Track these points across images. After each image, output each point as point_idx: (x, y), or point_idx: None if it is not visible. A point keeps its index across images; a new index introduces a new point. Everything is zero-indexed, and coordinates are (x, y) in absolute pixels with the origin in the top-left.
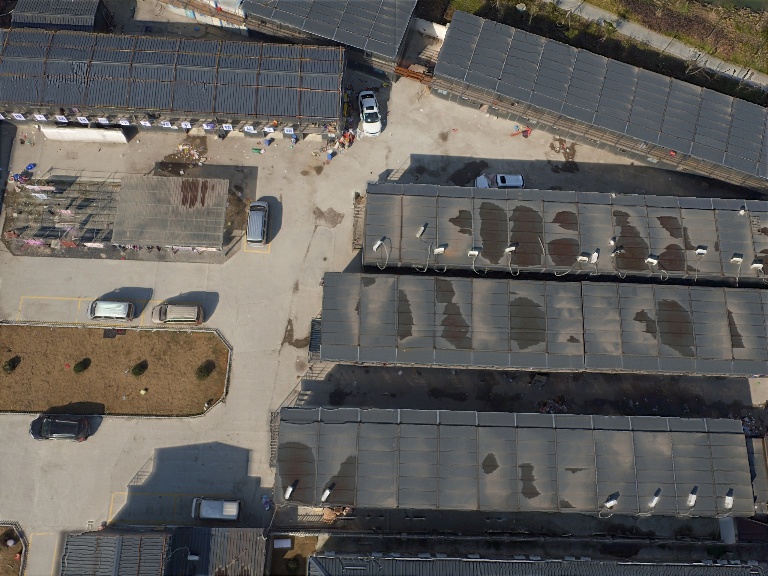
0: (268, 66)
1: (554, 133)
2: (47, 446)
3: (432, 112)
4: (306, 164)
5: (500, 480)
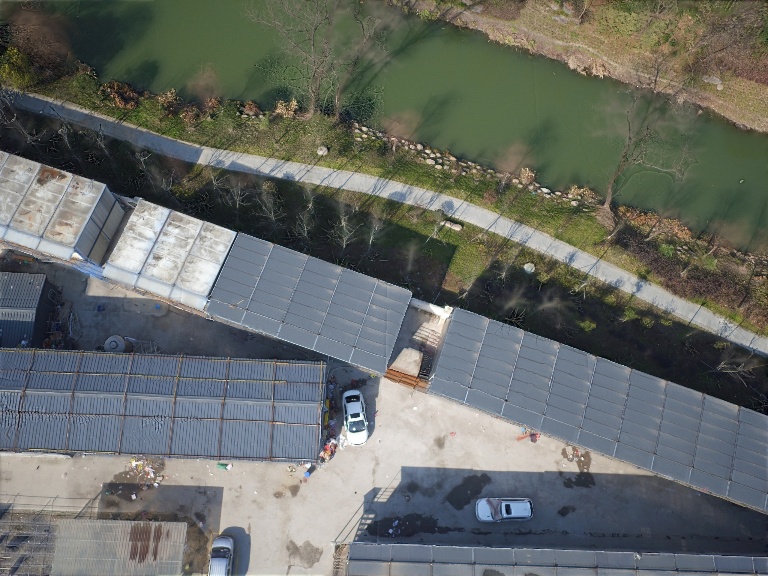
0: (235, 393)
1: None
2: None
3: (427, 410)
4: (280, 482)
5: None
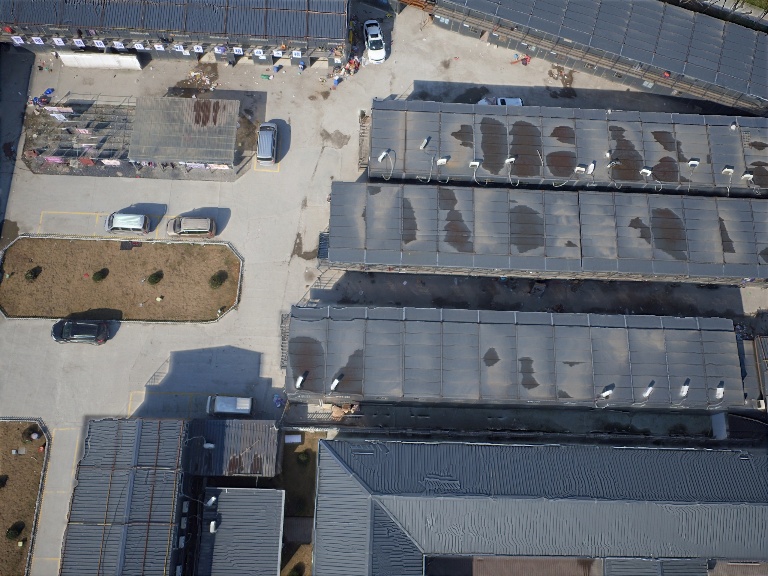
0: None
1: (552, 60)
2: (68, 349)
3: (434, 41)
4: (313, 89)
5: (501, 372)
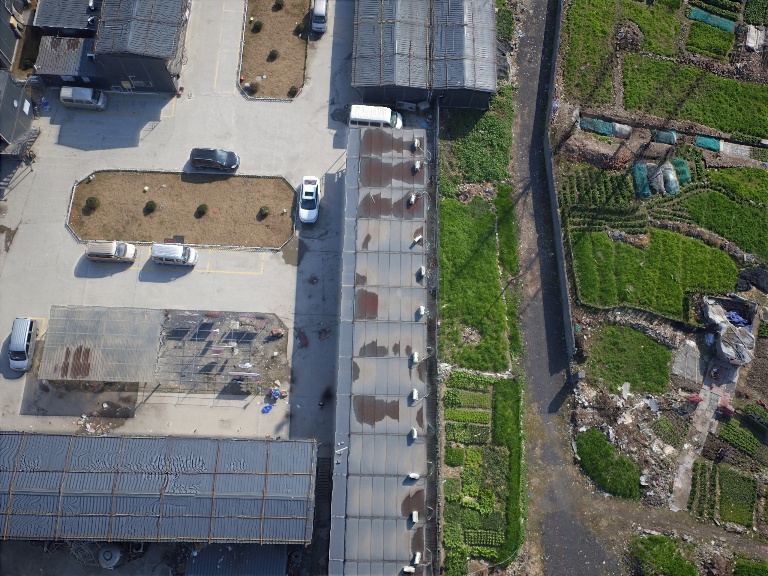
0: None
1: None
2: None
3: None
4: None
5: None
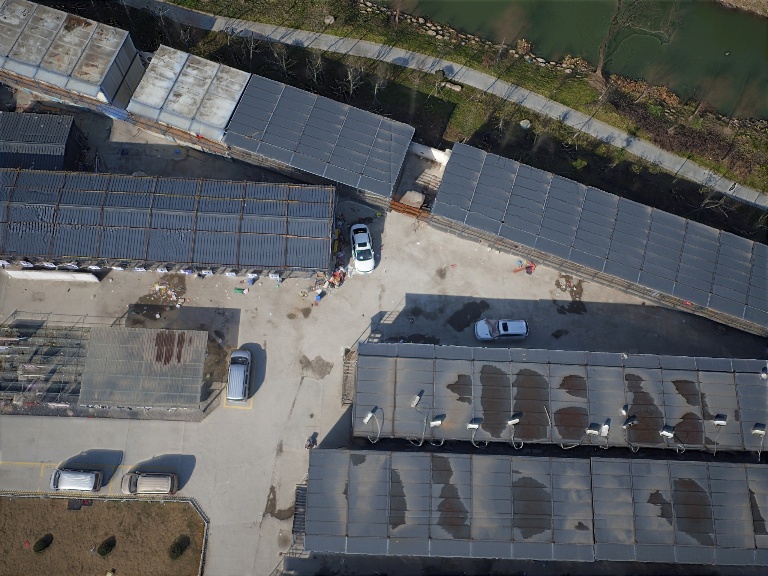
0: (252, 210)
1: (560, 270)
2: None
3: (429, 245)
4: (293, 306)
5: None
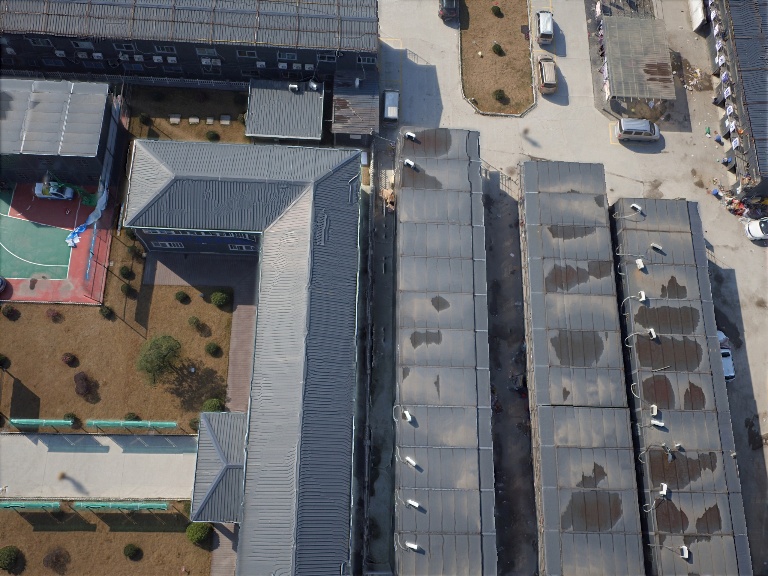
0: None
1: None
2: None
3: None
4: (703, 173)
5: (426, 312)
